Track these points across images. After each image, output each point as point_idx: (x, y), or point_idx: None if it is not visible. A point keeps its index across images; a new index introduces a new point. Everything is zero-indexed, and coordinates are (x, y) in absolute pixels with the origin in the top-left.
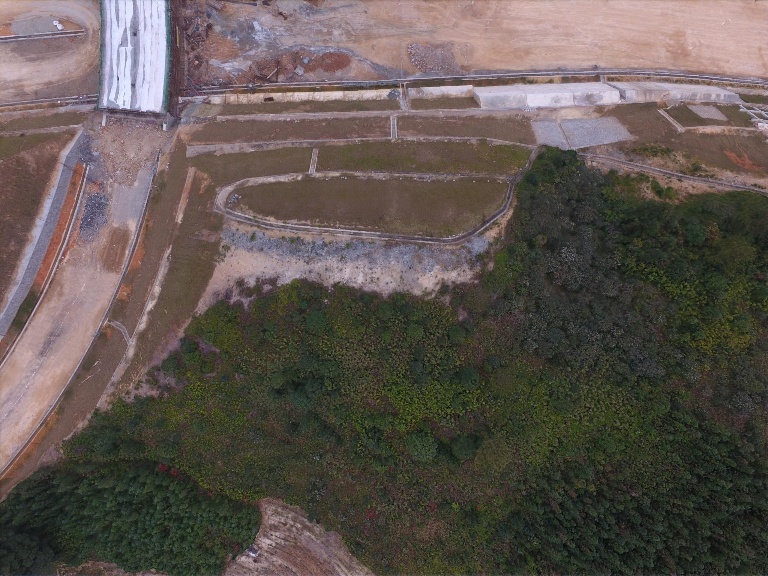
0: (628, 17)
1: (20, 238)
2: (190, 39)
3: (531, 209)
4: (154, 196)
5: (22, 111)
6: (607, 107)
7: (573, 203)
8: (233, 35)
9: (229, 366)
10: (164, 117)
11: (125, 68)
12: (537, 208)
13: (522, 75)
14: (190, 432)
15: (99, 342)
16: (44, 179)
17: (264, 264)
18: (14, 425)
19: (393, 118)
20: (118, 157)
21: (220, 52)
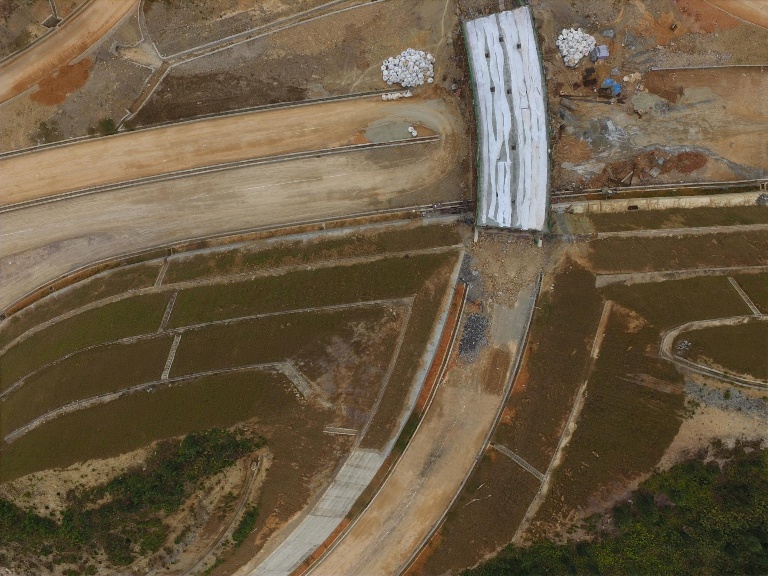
0: None
1: (414, 364)
2: None
3: None
4: (539, 318)
5: (387, 224)
6: None
7: None
8: (586, 136)
9: (682, 520)
10: (540, 233)
11: (504, 184)
12: None
13: None
14: (615, 574)
15: (483, 465)
16: (437, 305)
17: (743, 425)
18: (396, 543)
19: None
20: (501, 278)
21: (573, 154)
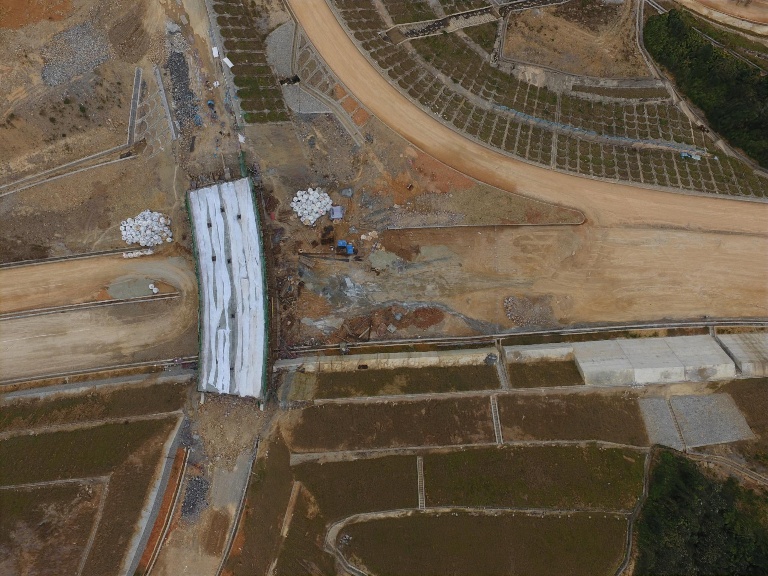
0: (742, 262)
1: (127, 531)
2: (282, 299)
3: (655, 568)
4: (254, 484)
5: (122, 382)
6: (721, 382)
7: (695, 540)
8: (325, 292)
9: None
10: None
11: (224, 351)
12: (663, 571)
13: (624, 328)
14: None
15: None
16: (149, 473)
17: None
18: None
19: (493, 398)
20: (218, 444)
21: (312, 310)
